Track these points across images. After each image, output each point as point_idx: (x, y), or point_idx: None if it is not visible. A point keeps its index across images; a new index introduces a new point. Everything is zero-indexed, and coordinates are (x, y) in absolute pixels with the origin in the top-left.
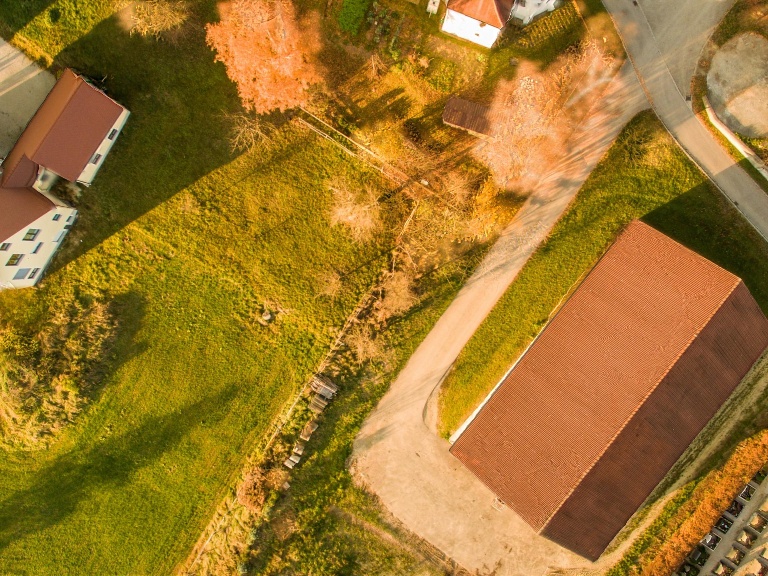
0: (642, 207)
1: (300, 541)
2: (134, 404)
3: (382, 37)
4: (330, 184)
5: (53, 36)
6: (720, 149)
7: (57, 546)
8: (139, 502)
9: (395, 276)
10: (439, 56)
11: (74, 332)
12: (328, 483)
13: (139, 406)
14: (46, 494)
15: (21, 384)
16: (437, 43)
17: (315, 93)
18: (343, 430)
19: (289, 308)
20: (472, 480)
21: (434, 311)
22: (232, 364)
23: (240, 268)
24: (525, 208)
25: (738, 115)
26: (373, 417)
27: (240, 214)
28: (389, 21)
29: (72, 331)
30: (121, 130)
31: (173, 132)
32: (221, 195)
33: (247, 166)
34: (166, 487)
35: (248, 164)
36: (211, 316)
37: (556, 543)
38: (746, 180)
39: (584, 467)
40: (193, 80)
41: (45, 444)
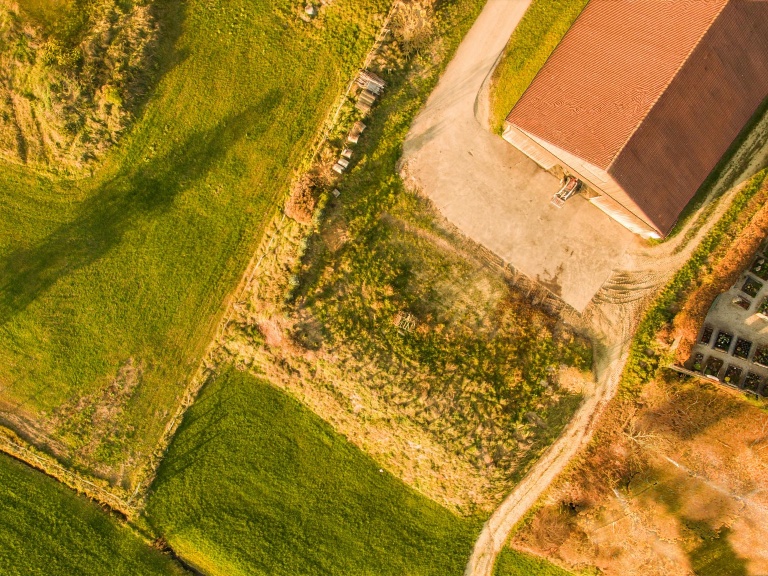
0: None
1: (352, 250)
2: (178, 119)
3: None
4: None
5: None
6: None
7: (105, 281)
8: (186, 229)
9: None
10: None
11: (115, 38)
12: (379, 189)
13: (183, 121)
14: (92, 225)
15: (64, 96)
16: None
17: None
18: (392, 130)
19: None
20: (528, 178)
21: None
22: (275, 67)
23: None
24: None
25: None
26: (422, 115)
27: None
28: None
29: (113, 38)
30: None
31: None
32: None
33: None
34: (213, 210)
35: None
36: (252, 15)
37: (625, 192)
38: None
39: (651, 98)
40: None
41: (89, 171)
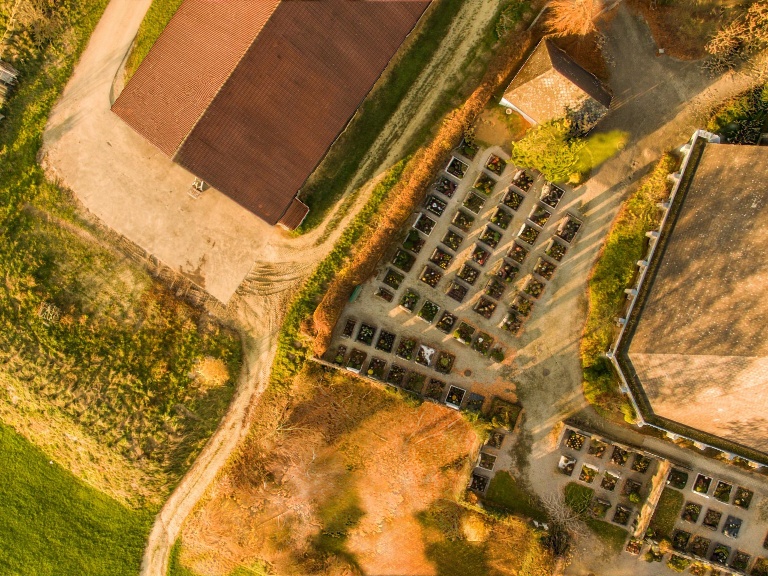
0: None
1: None
2: None
3: None
4: None
5: None
6: None
7: None
8: None
9: None
10: None
11: None
12: (20, 179)
13: None
14: None
15: None
16: None
17: None
18: (30, 120)
19: None
20: (167, 169)
21: None
22: None
23: None
24: None
25: None
26: (60, 105)
27: None
28: None
29: None
30: None
31: None
32: None
33: None
34: None
35: None
36: None
37: None
38: None
39: (217, 86)
40: None
41: None
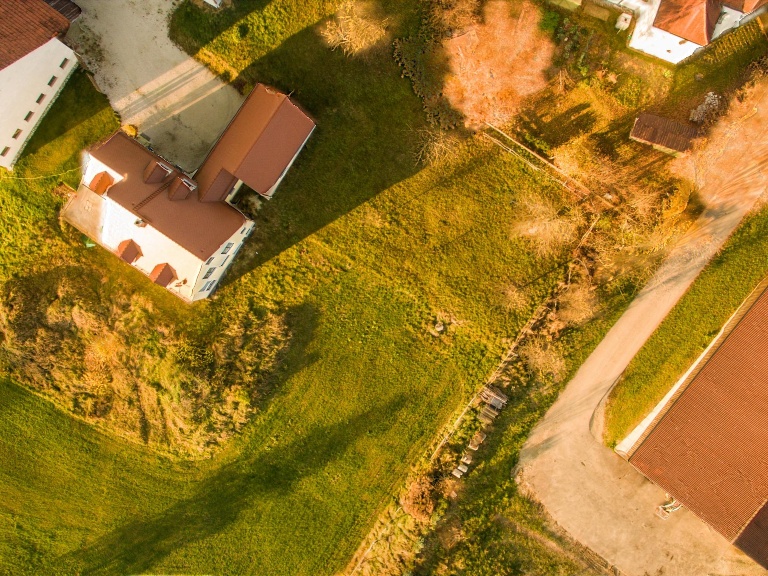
0: None
1: (466, 549)
2: (302, 414)
3: (571, 53)
4: (511, 197)
5: (240, 51)
6: None
7: (218, 555)
8: (301, 511)
9: (570, 288)
10: (626, 72)
11: (248, 343)
12: (494, 492)
13: (306, 416)
14: (209, 503)
15: (194, 395)
16: (624, 59)
17: (500, 108)
18: (510, 440)
19: (463, 319)
20: (636, 489)
21: (605, 322)
22: (402, 375)
23: (417, 280)
24: (700, 221)
25: None
26: (540, 427)
27: (420, 227)
28: (579, 37)
29: (246, 342)
30: (305, 144)
31: (357, 146)
32: (402, 208)
33: (429, 180)
34: (329, 496)
35: (430, 178)
36: (384, 327)
37: None
38: None
39: None
40: (380, 95)
41: (210, 454)
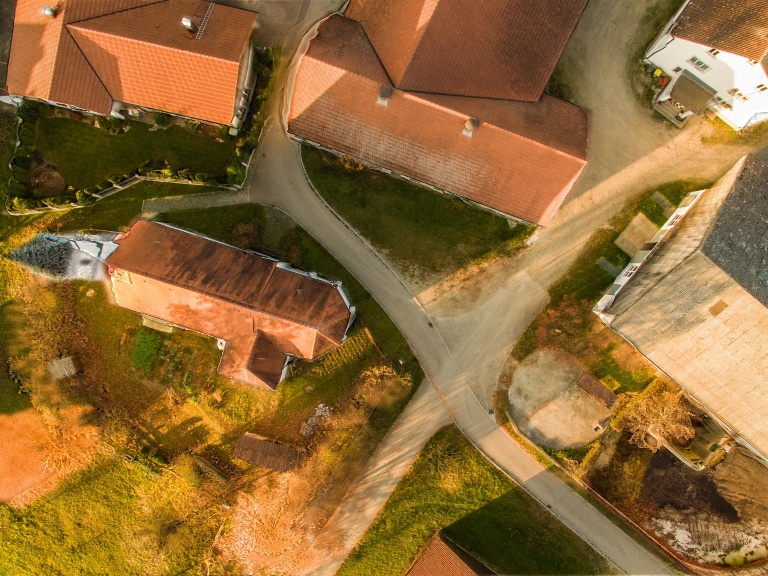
0: (452, 514)
1: None
2: None
3: (176, 372)
4: (139, 503)
5: None
6: (528, 457)
7: None
8: None
9: None
10: (233, 388)
11: None
12: None
13: None
14: None
15: None
16: None
17: (118, 420)
18: None
19: None
20: None
21: None
22: None
23: (61, 575)
24: (335, 517)
25: (542, 428)
26: None
27: (56, 528)
28: (181, 357)
29: None
30: None
31: None
32: (36, 511)
33: (58, 486)
34: None
35: (59, 484)
36: None
37: None
38: (558, 484)
39: None
40: (0, 409)
41: None
